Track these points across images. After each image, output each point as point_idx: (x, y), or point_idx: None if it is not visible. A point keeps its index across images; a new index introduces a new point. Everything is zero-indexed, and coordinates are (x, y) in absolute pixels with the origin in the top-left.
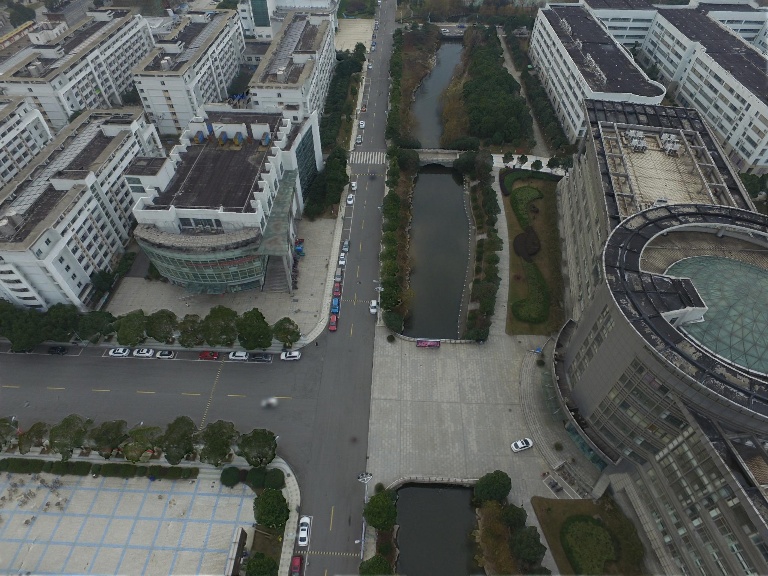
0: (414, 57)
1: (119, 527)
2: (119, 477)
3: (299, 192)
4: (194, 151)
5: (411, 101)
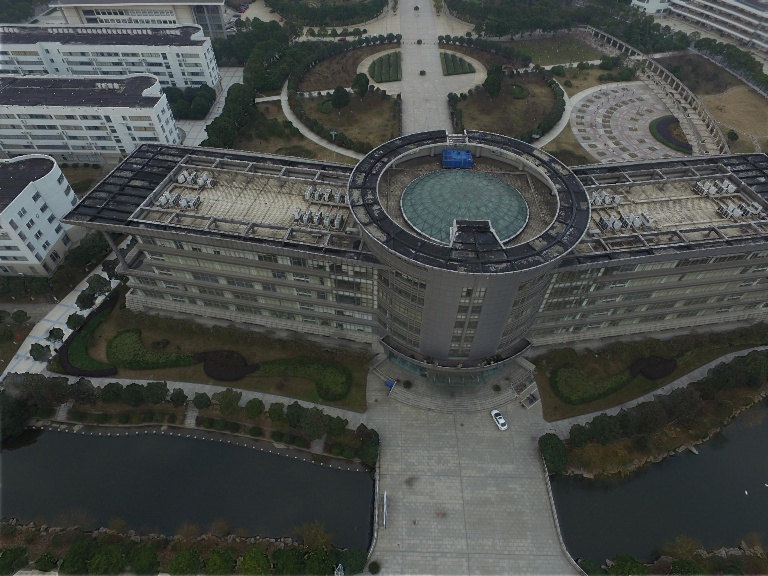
0: None
1: None
2: None
3: None
4: None
5: None
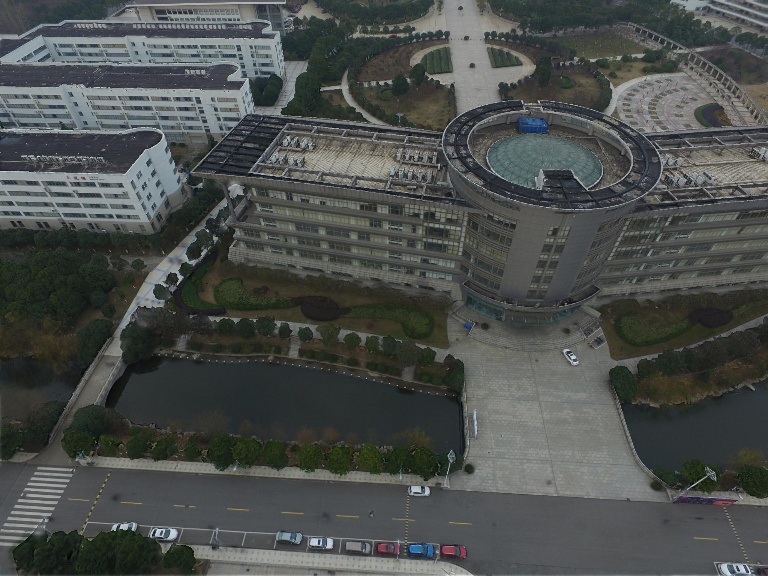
0: None
1: None
2: None
3: None
4: None
5: None
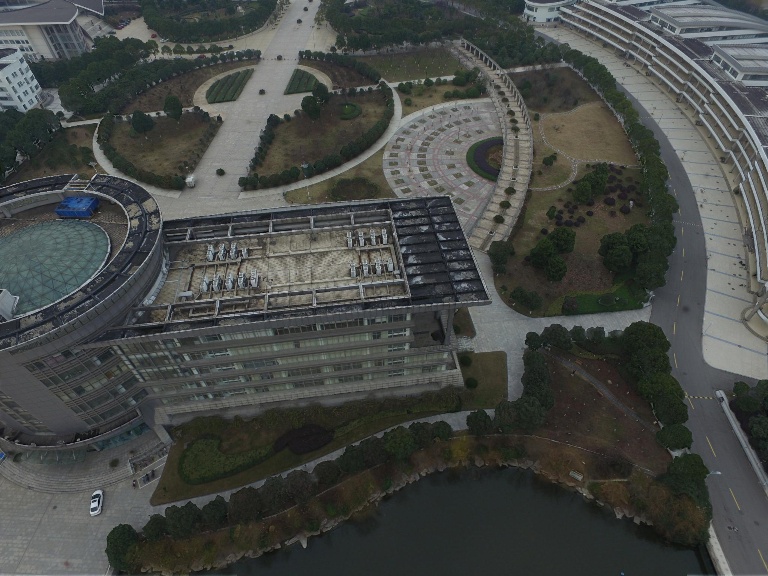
0: None
1: None
2: None
3: None
4: None
5: None
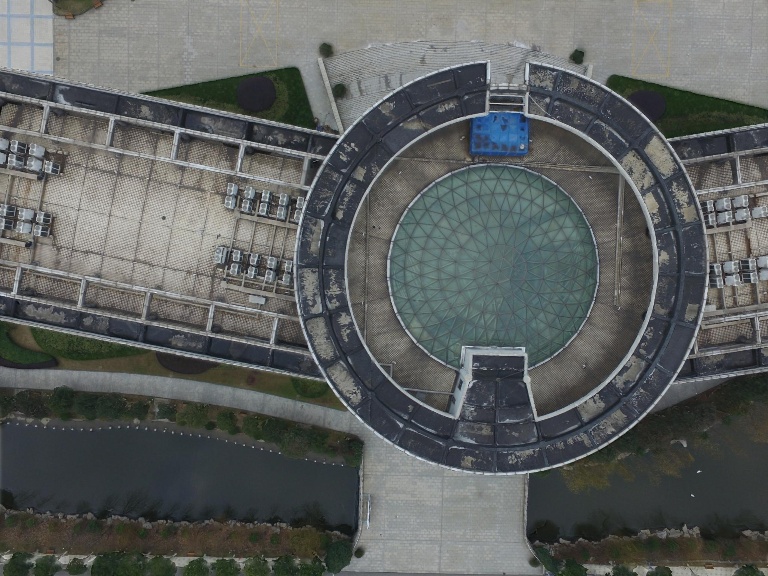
0: None
1: None
2: None
3: None
4: None
5: None
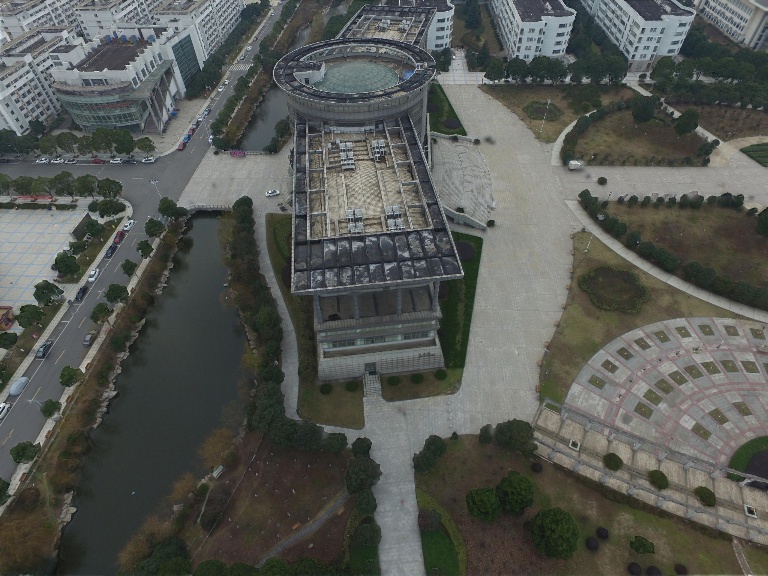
0: (310, 7)
1: (26, 226)
2: (31, 209)
3: (180, 80)
4: (102, 47)
5: (296, 35)
